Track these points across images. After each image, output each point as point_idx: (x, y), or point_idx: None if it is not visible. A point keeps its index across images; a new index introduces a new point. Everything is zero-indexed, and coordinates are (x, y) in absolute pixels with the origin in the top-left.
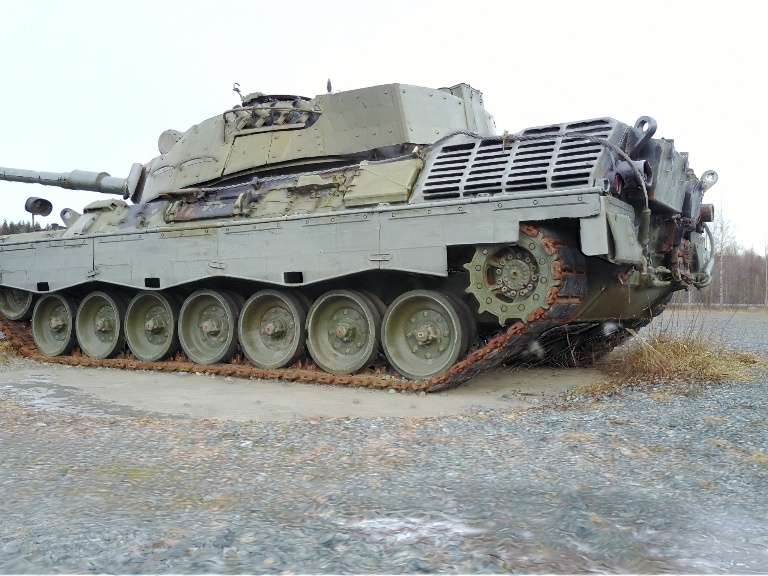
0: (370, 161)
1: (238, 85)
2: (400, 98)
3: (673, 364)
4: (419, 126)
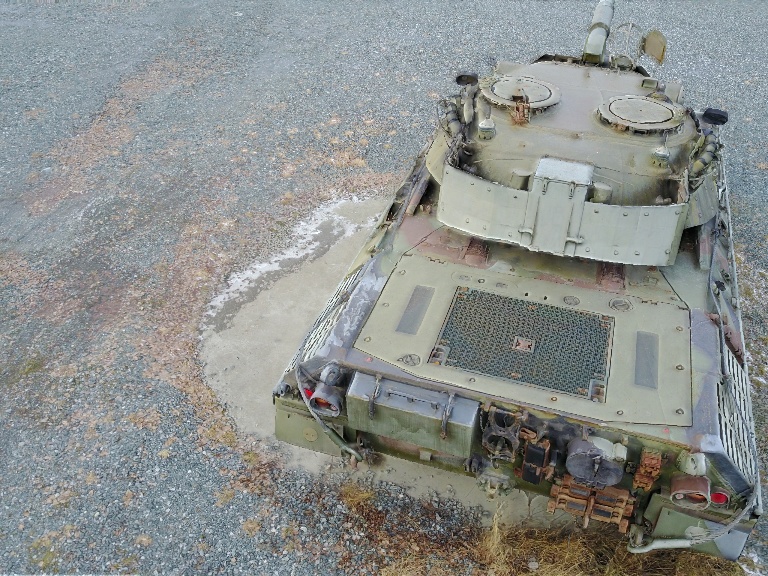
0: (395, 226)
1: (494, 59)
2: (443, 177)
3: (488, 555)
4: (452, 209)
